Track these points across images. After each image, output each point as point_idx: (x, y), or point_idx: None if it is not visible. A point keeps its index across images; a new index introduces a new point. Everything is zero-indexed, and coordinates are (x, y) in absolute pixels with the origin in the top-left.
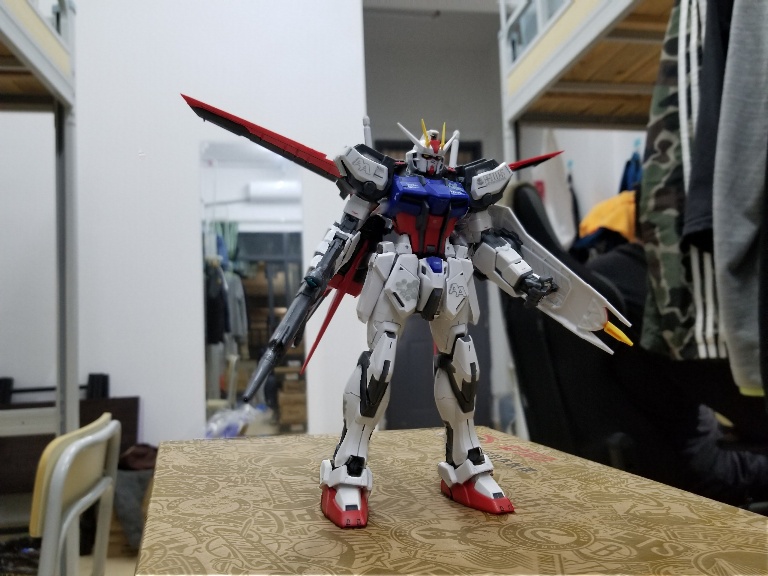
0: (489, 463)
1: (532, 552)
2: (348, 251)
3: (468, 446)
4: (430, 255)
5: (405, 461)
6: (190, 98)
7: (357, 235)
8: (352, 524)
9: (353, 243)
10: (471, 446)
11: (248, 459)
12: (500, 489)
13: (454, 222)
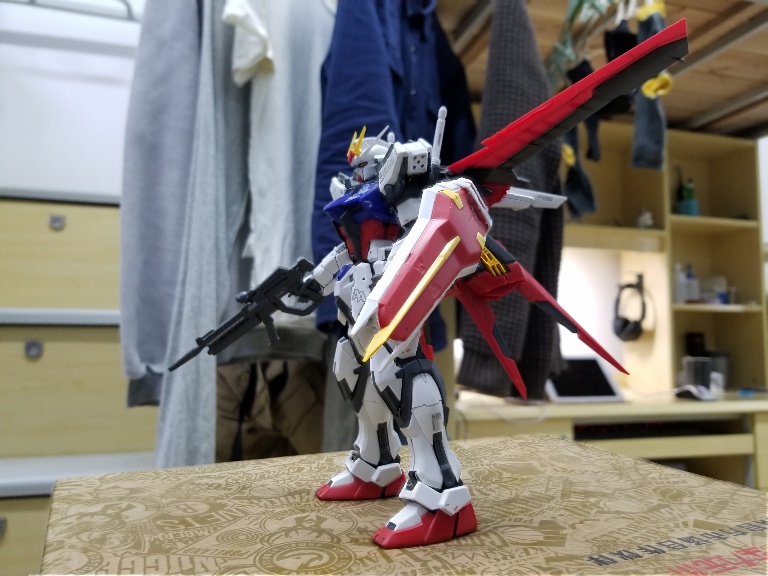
0: (414, 492)
1: (253, 549)
2: (339, 267)
3: (411, 467)
4: (355, 263)
5: (586, 505)
6: None
7: (342, 253)
8: (317, 493)
9: (339, 260)
10: (413, 468)
11: (510, 457)
12: (400, 522)
13: (372, 225)
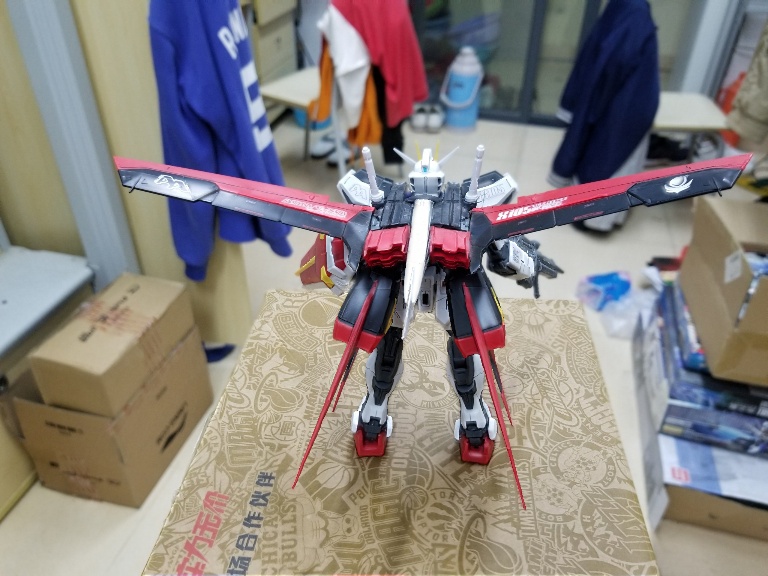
0: None
1: None
2: None
3: None
4: None
5: (355, 570)
6: (736, 158)
7: None
8: None
9: None
10: None
11: None
12: None
13: None
